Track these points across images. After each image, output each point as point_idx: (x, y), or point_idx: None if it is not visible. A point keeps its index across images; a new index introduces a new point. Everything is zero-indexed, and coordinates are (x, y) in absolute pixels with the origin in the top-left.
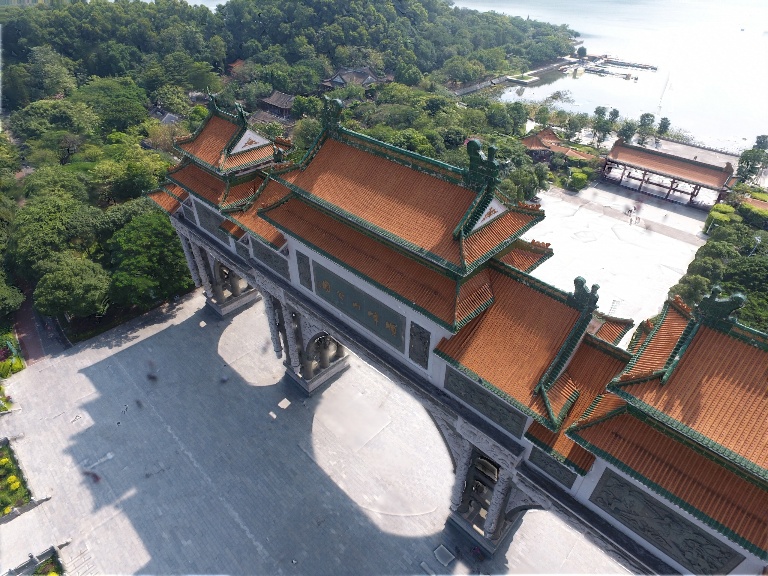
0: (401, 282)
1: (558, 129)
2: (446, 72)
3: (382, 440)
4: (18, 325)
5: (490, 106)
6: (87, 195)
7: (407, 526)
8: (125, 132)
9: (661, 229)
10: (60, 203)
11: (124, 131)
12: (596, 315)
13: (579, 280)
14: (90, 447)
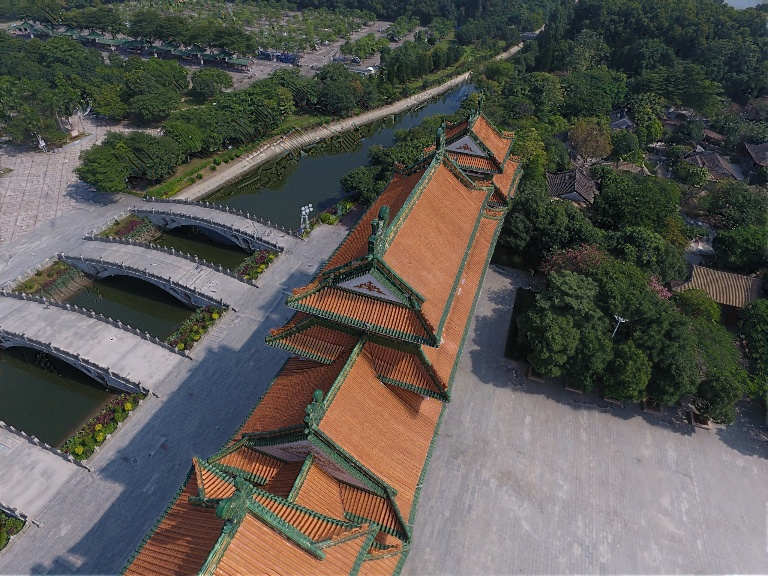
0: None
1: None
2: None
3: None
4: (361, 203)
5: None
6: None
7: None
8: (569, 119)
9: None
10: None
11: (570, 118)
12: (356, 466)
13: None
14: (295, 283)
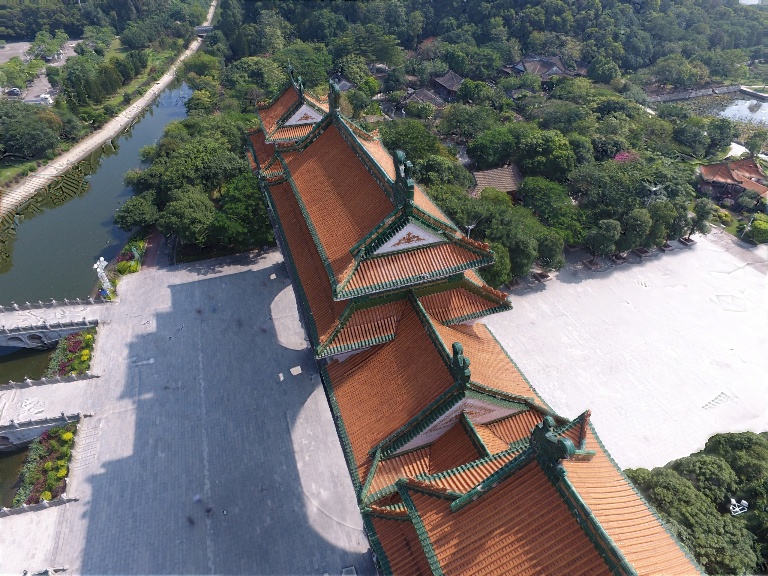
0: (316, 287)
1: None
2: (654, 72)
3: None
4: (151, 237)
5: (688, 119)
6: (241, 143)
7: (333, 532)
8: None
9: None
10: (208, 145)
11: None
12: (502, 396)
13: (455, 346)
14: (143, 349)
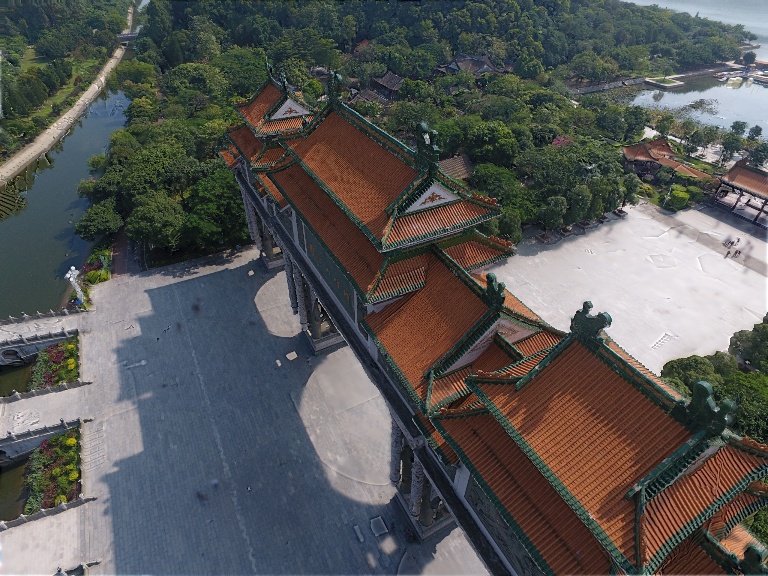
0: (346, 251)
1: (677, 141)
2: (572, 67)
3: (364, 409)
4: (116, 245)
5: (607, 108)
6: (195, 147)
7: (356, 490)
8: (245, 97)
9: (763, 269)
10: (166, 150)
11: (245, 96)
12: (523, 319)
13: (489, 276)
14: (132, 352)
